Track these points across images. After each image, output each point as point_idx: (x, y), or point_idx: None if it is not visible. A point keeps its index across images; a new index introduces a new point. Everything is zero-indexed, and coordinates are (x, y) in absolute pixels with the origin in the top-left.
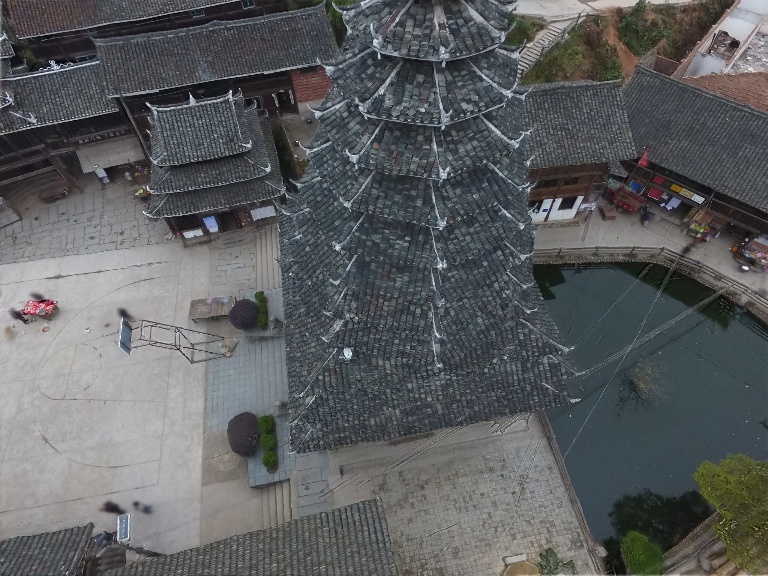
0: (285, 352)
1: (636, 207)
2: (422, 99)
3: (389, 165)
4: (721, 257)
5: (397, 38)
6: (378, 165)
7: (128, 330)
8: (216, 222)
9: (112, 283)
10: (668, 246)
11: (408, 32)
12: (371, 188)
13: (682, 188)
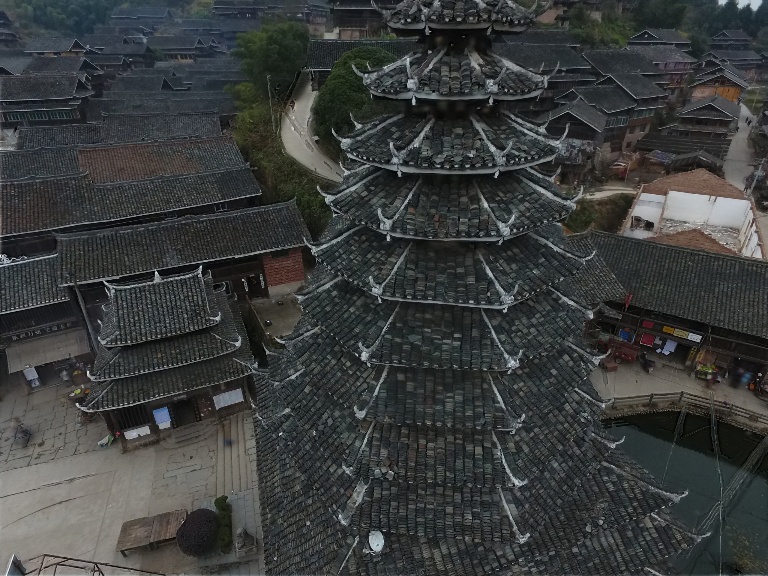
0: None
1: (634, 355)
2: (466, 147)
3: (432, 229)
4: (743, 397)
5: (434, 80)
6: (418, 230)
7: (18, 575)
8: (169, 415)
9: (11, 512)
10: (684, 391)
11: (445, 76)
12: (405, 270)
13: (674, 329)
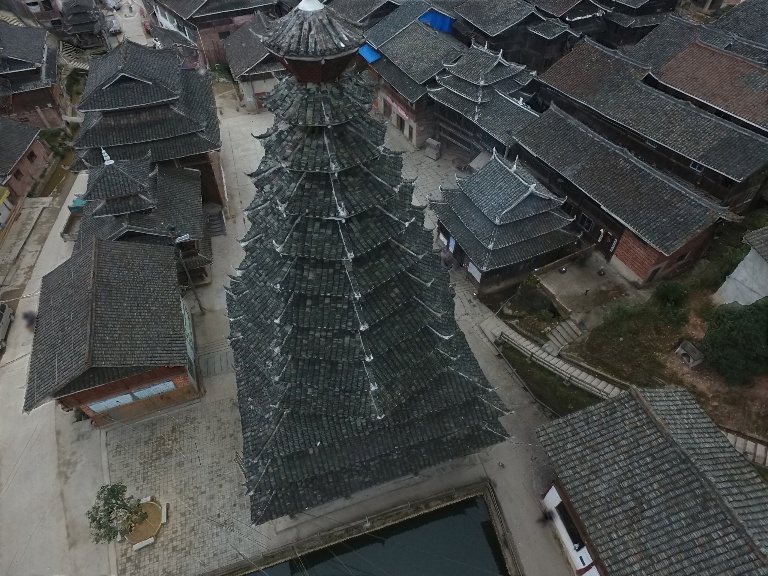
0: None
1: None
2: None
3: None
4: None
5: None
6: None
7: None
8: None
9: None
10: None
11: None
12: None
13: None
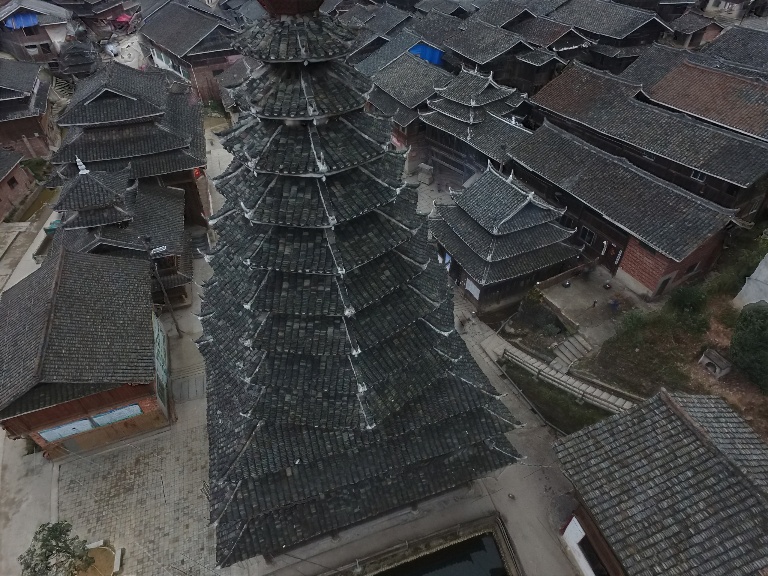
0: None
1: None
2: None
3: None
4: None
5: None
6: (235, 159)
7: None
8: None
9: None
10: None
11: None
12: None
13: None
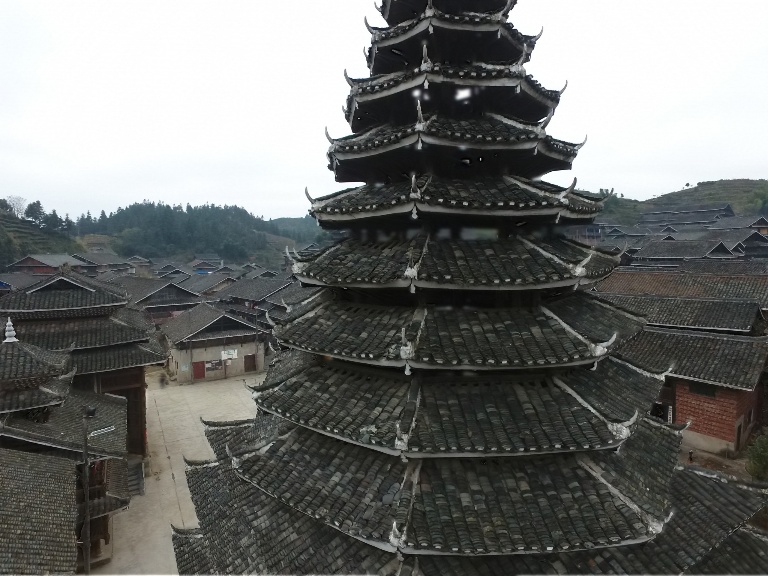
0: None
1: None
2: None
3: None
4: None
5: None
6: None
7: None
8: None
9: None
10: None
11: None
12: None
13: None
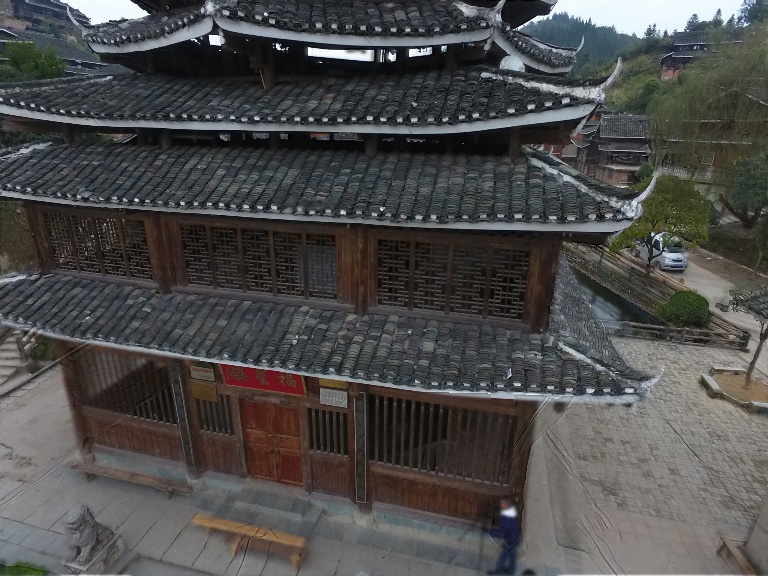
0: (178, 575)
1: None
2: None
3: None
4: None
5: None
6: None
7: None
8: None
9: None
10: None
11: None
12: None
13: None
